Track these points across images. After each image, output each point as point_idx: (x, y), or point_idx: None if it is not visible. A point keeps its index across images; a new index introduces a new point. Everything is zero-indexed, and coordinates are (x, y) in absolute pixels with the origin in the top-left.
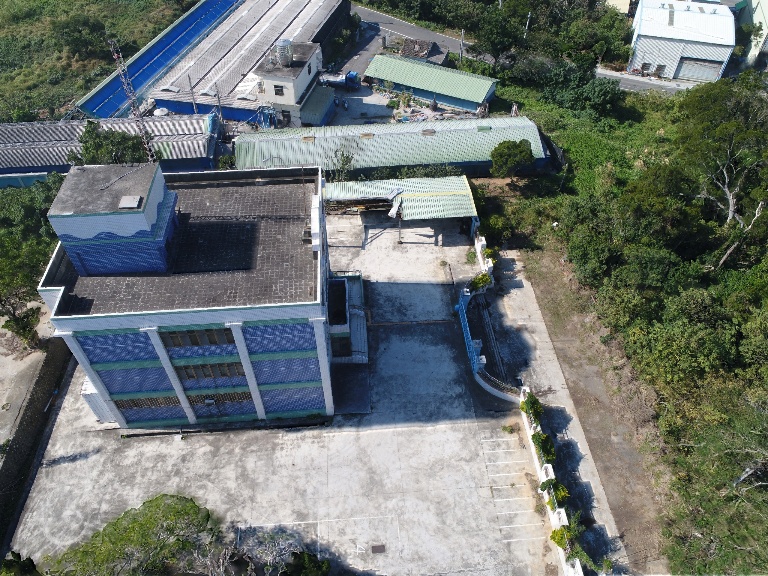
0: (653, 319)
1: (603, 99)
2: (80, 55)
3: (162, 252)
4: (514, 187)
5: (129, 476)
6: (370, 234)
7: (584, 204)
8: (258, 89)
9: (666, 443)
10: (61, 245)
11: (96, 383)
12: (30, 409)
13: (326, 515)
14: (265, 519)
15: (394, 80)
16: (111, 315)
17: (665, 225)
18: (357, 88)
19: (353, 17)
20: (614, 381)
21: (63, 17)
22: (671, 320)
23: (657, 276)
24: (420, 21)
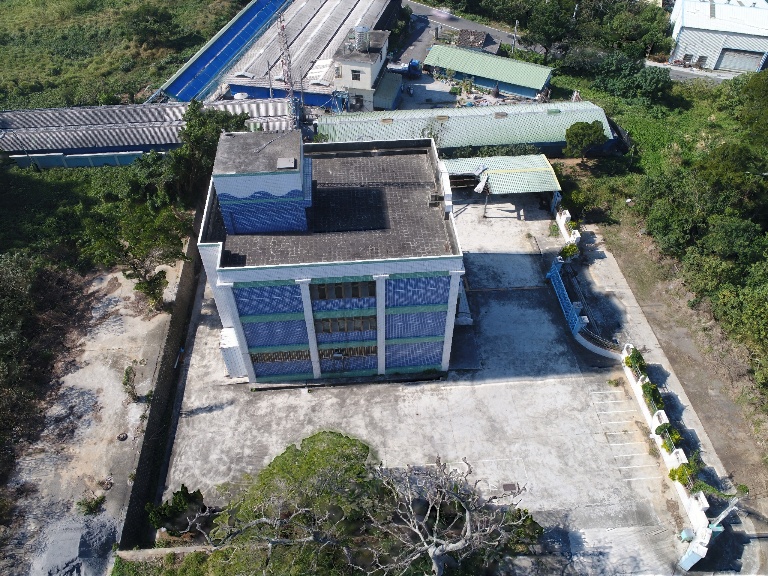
0: (737, 284)
1: (655, 87)
2: (147, 44)
3: (305, 212)
4: (584, 167)
5: (265, 424)
6: (455, 209)
7: (659, 180)
8: (330, 75)
9: (763, 395)
10: (208, 207)
11: (240, 336)
12: (164, 365)
13: (456, 458)
14: (399, 461)
15: (454, 68)
16: (272, 266)
17: (742, 198)
18: (419, 76)
19: (405, 9)
20: (705, 341)
21: (125, 8)
22: (755, 285)
23: (745, 242)
24: (466, 14)
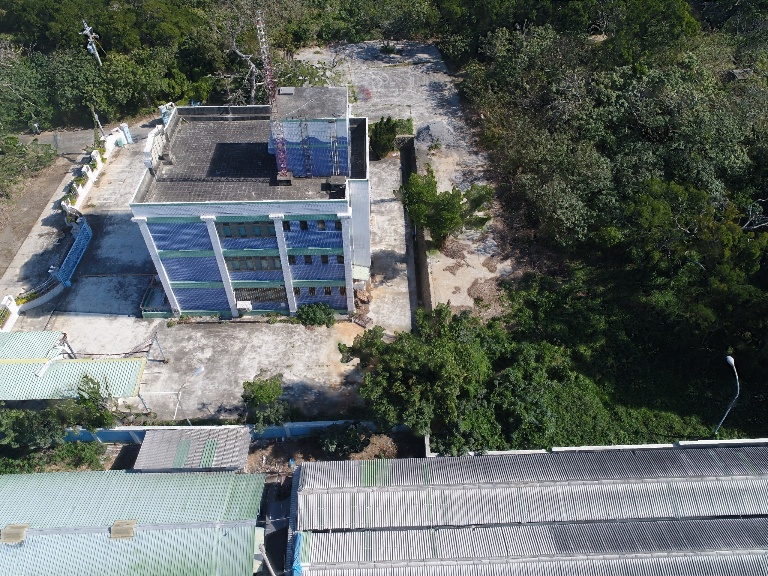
0: None
1: None
2: None
3: None
4: None
5: None
6: None
7: None
8: None
9: None
10: None
11: None
12: None
13: None
14: None
15: None
16: None
17: None
18: None
19: None
20: None
21: None
22: None
23: None
24: None
